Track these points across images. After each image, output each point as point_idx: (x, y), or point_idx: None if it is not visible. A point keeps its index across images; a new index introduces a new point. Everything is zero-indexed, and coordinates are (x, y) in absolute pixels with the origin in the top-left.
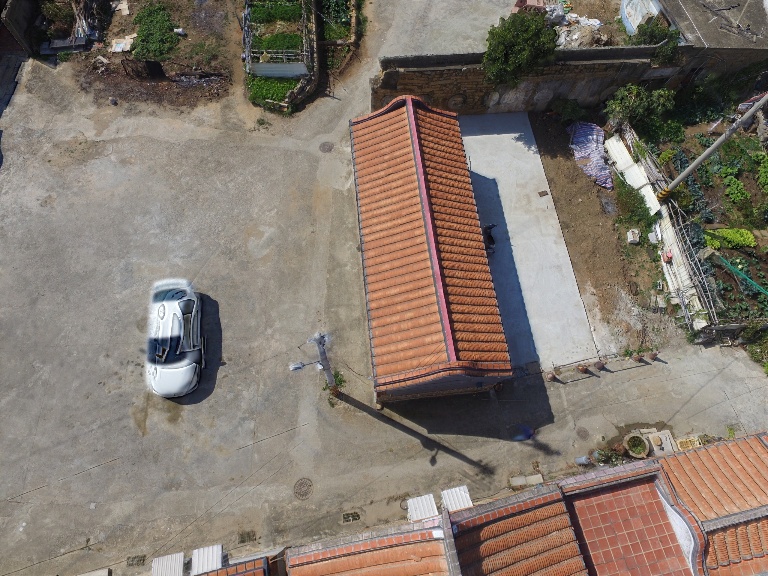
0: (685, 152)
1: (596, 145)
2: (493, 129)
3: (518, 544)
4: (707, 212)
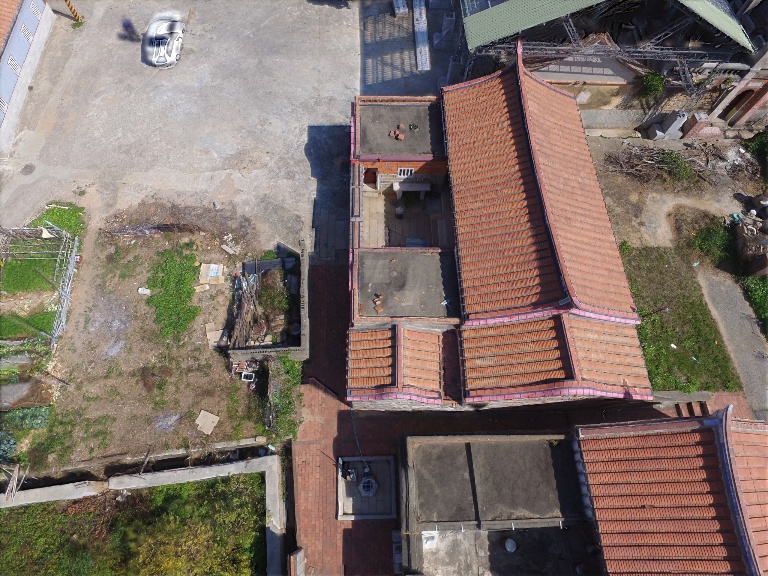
0: None
1: None
2: None
3: None
4: None
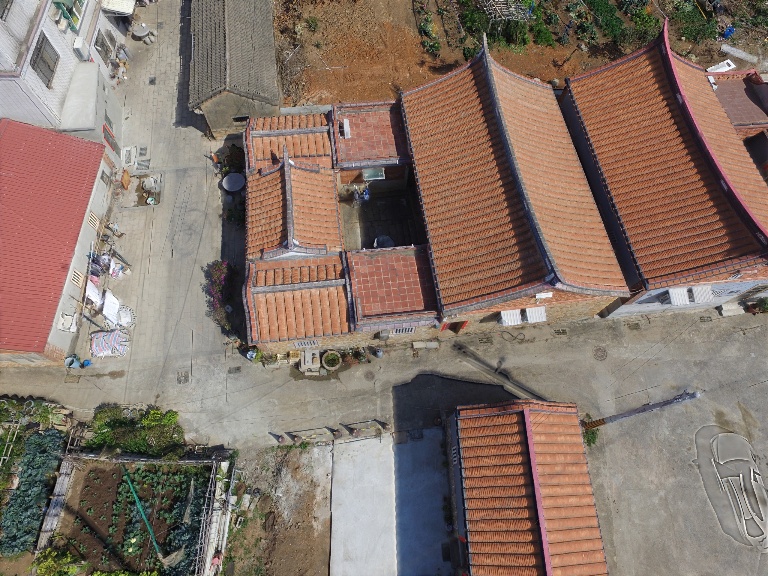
0: None
1: None
2: None
3: (487, 278)
4: None
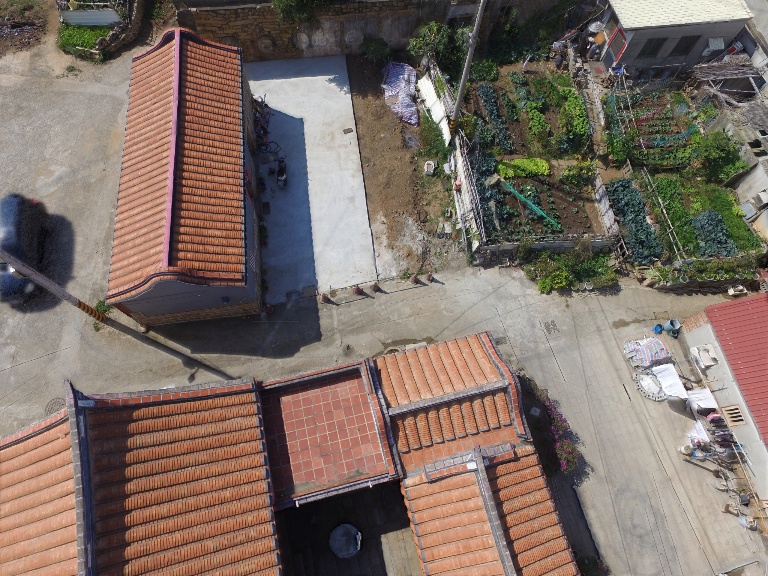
0: (497, 90)
1: (405, 84)
2: (308, 72)
3: (184, 426)
4: (505, 143)
